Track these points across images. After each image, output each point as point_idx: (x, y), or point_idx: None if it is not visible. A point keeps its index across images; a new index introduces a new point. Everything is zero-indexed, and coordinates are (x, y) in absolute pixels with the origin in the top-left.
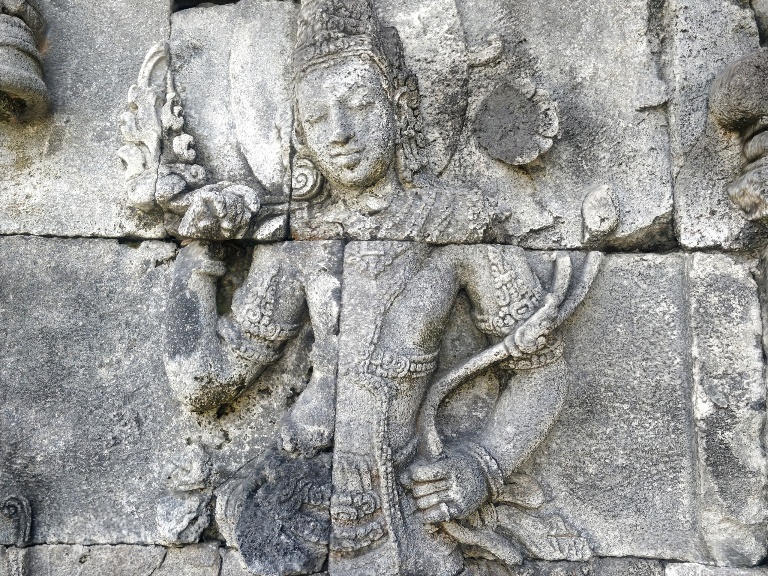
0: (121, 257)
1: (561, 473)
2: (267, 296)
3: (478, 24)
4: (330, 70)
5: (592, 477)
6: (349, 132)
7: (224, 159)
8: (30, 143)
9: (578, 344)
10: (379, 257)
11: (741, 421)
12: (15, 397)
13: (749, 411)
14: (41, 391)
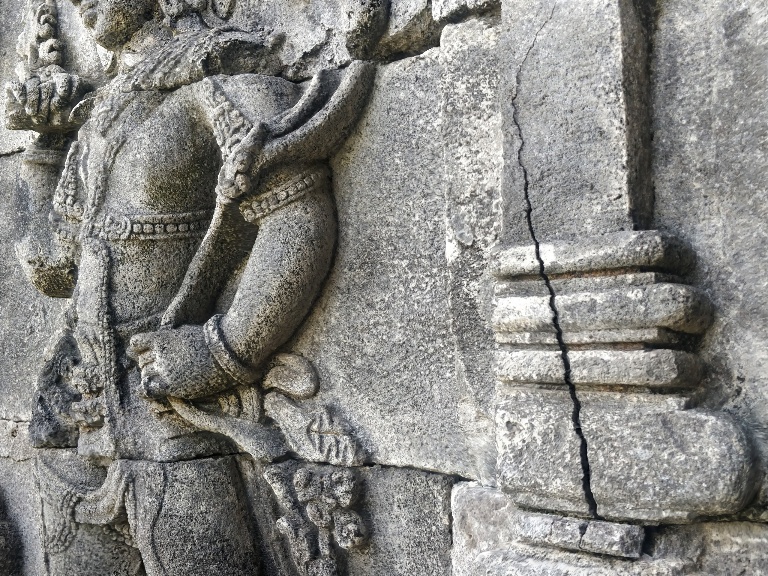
0: None
1: (339, 354)
2: (68, 176)
3: None
4: None
5: (369, 359)
6: None
7: (86, 55)
8: None
9: (357, 187)
10: (108, 113)
11: (488, 263)
12: None
13: None
14: None
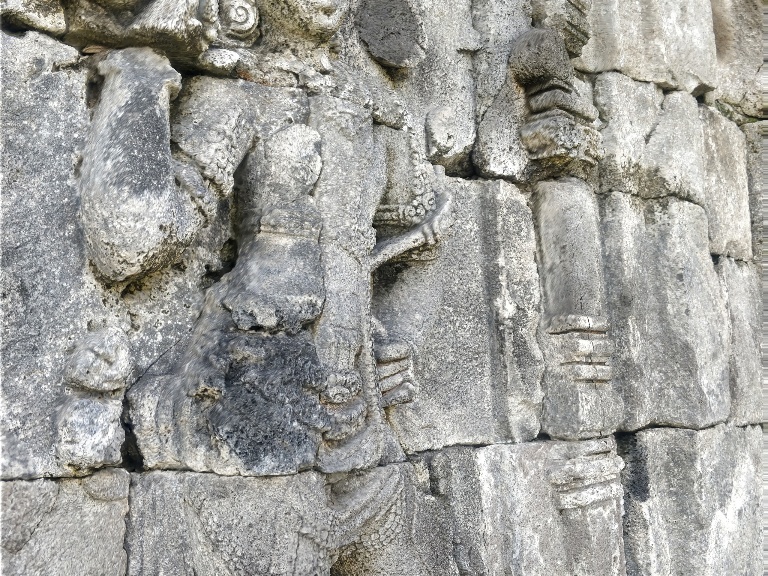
0: None
1: None
2: (234, 138)
3: None
4: None
5: (434, 373)
6: None
7: None
8: None
9: None
10: (353, 117)
11: (531, 320)
12: None
13: (534, 312)
14: None
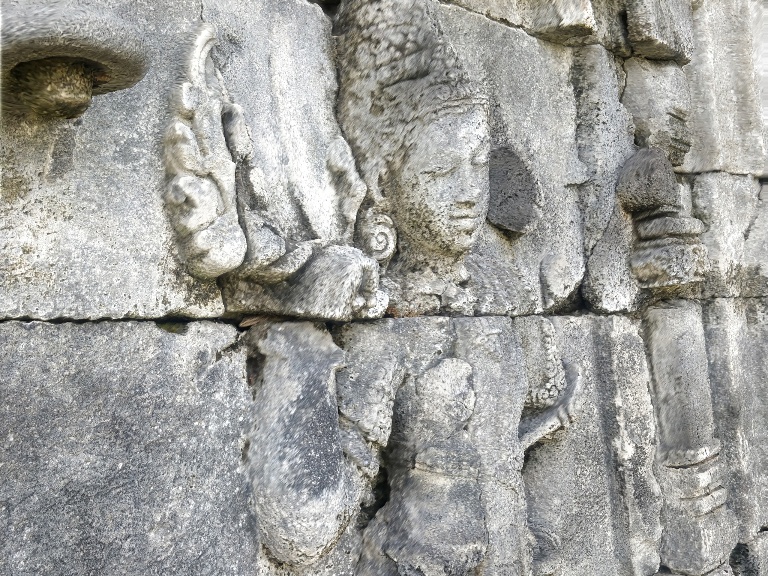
0: (166, 349)
1: None
2: (391, 391)
3: None
4: (464, 117)
5: None
6: None
7: (279, 205)
8: (23, 153)
9: None
10: (499, 335)
11: None
12: None
13: (651, 446)
14: None
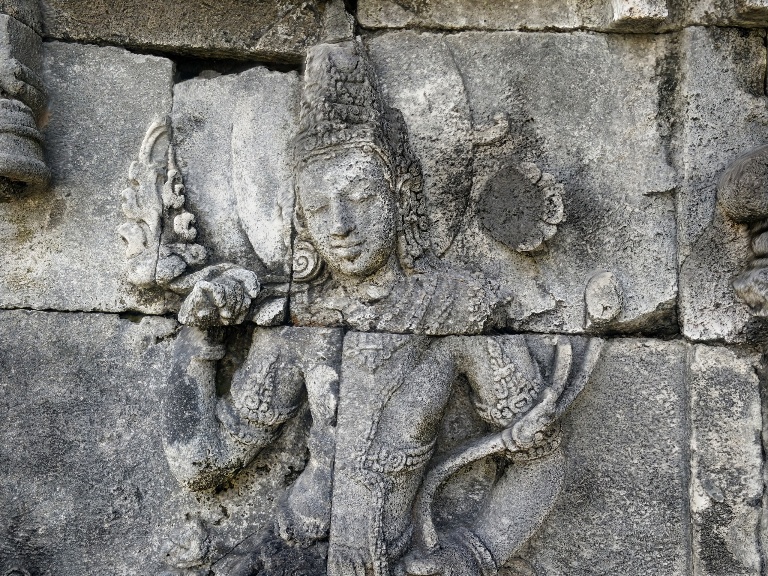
0: (122, 332)
1: (555, 557)
2: (266, 383)
3: (485, 101)
4: (332, 162)
5: (586, 561)
6: (350, 226)
7: (225, 236)
8: (31, 217)
9: (577, 429)
10: (378, 351)
11: (737, 517)
12: (17, 471)
13: (745, 507)
14: (42, 465)
